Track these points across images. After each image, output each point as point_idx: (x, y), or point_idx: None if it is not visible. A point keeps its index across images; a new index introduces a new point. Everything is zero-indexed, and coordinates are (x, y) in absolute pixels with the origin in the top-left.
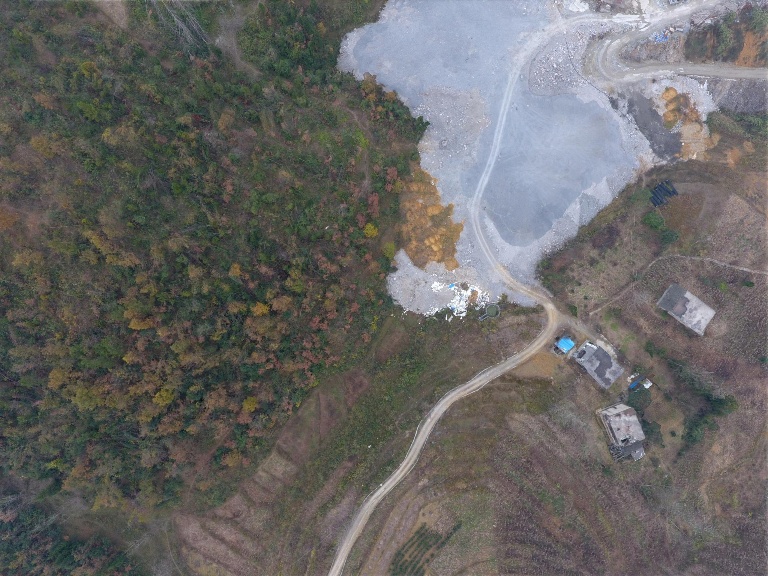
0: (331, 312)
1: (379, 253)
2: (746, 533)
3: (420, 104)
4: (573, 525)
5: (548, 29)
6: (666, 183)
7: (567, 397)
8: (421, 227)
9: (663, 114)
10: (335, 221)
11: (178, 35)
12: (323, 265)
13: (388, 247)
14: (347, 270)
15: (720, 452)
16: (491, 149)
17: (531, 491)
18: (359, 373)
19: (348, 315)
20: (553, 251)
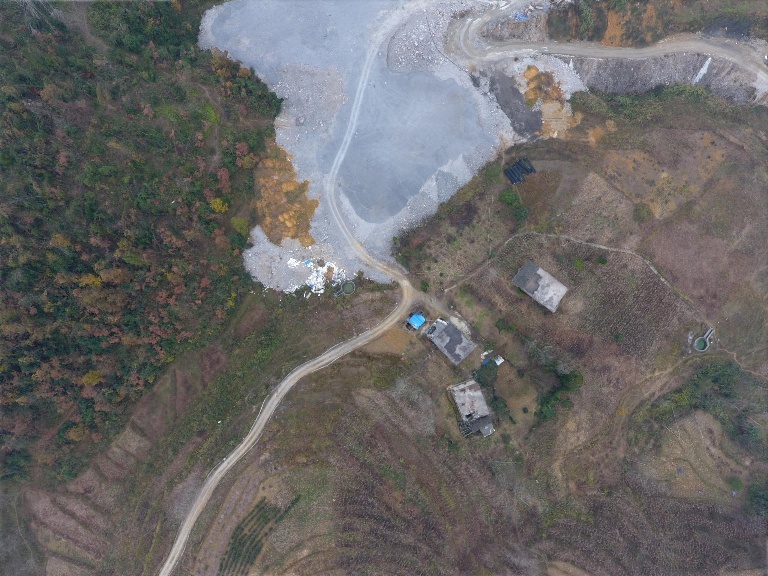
0: (178, 287)
1: (233, 229)
2: (600, 510)
3: (279, 81)
4: (414, 500)
5: (408, 7)
6: (524, 161)
7: (417, 373)
8: (275, 203)
9: (524, 92)
10: (180, 195)
11: (23, 9)
12: (167, 239)
13: (234, 222)
14: (198, 245)
15: (574, 429)
16: (348, 126)
17: (373, 466)
18: (216, 350)
19: (199, 290)
20: (411, 228)
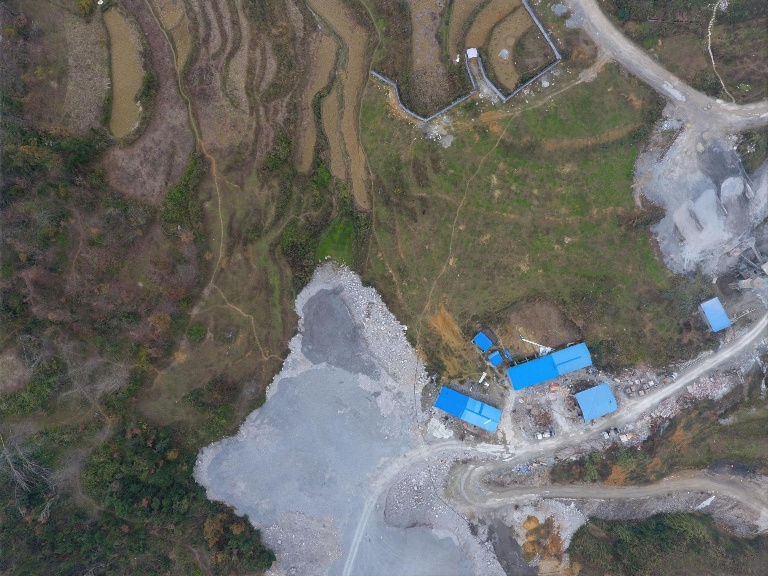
0: None
1: None
2: None
3: (273, 524)
4: None
5: (410, 455)
6: None
7: None
8: None
9: (523, 544)
10: None
11: (14, 479)
12: None
13: None
14: None
15: None
16: None
17: None
18: None
19: None
20: None
